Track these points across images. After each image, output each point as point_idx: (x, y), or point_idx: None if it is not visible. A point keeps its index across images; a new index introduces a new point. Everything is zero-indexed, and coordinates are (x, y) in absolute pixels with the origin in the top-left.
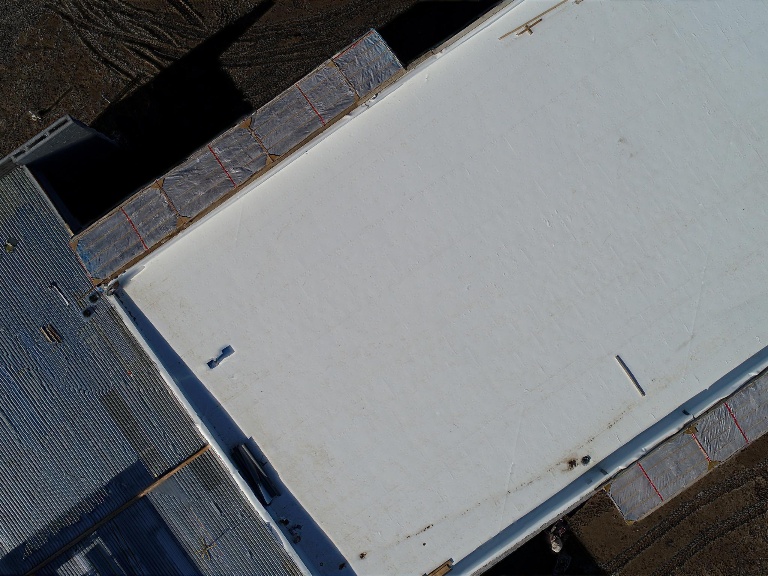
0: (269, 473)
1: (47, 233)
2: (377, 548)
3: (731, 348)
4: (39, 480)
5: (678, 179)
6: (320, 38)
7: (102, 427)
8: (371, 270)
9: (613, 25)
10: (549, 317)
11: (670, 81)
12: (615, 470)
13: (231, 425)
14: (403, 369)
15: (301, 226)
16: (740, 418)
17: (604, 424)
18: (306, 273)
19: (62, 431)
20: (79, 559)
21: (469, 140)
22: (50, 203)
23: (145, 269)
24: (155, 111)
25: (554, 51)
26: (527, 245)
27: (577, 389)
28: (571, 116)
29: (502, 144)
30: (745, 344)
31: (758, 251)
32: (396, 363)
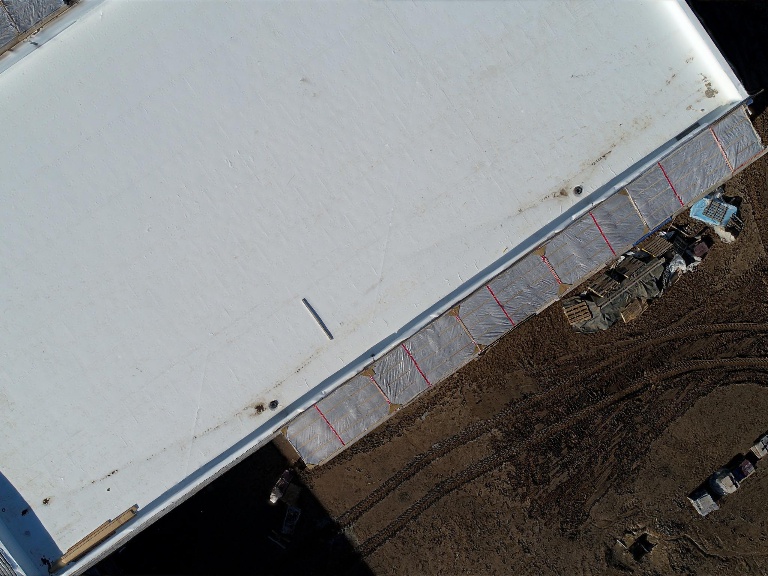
0: None
1: None
2: (61, 494)
3: (420, 291)
4: None
5: (363, 119)
6: None
7: None
8: (48, 211)
9: None
10: (233, 259)
11: (353, 19)
12: (293, 413)
13: None
14: (83, 312)
15: None
16: (420, 360)
17: (292, 368)
18: None
19: None
20: None
21: (147, 79)
22: None
23: None
24: None
25: None
26: (209, 186)
27: (263, 333)
28: (251, 54)
29: (181, 83)
30: (434, 287)
31: (447, 193)
32: (76, 306)
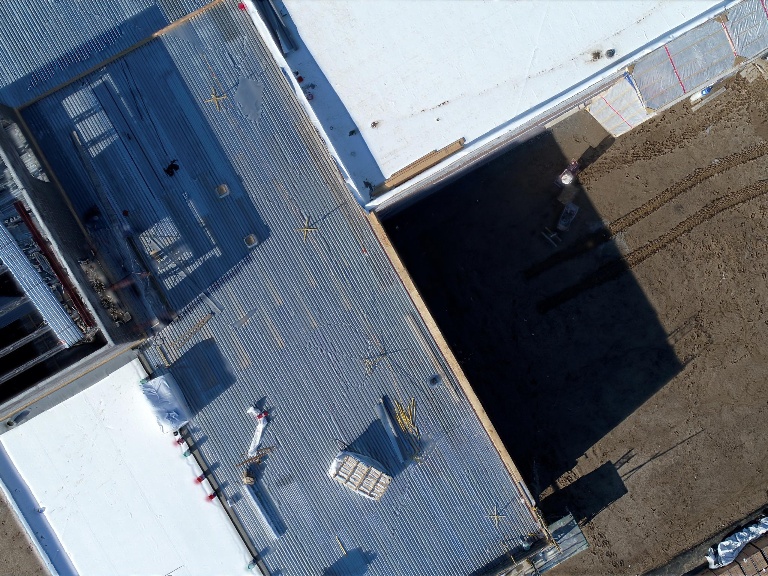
0: (288, 25)
1: None
2: (389, 118)
3: None
4: (52, 12)
5: None
6: None
7: None
8: None
9: None
10: None
11: None
12: (640, 53)
13: None
14: None
15: None
16: None
17: (632, 18)
18: None
19: None
20: (85, 93)
21: None
22: None
23: None
24: None
25: None
26: None
27: None
28: None
29: None
30: None
31: None
32: None
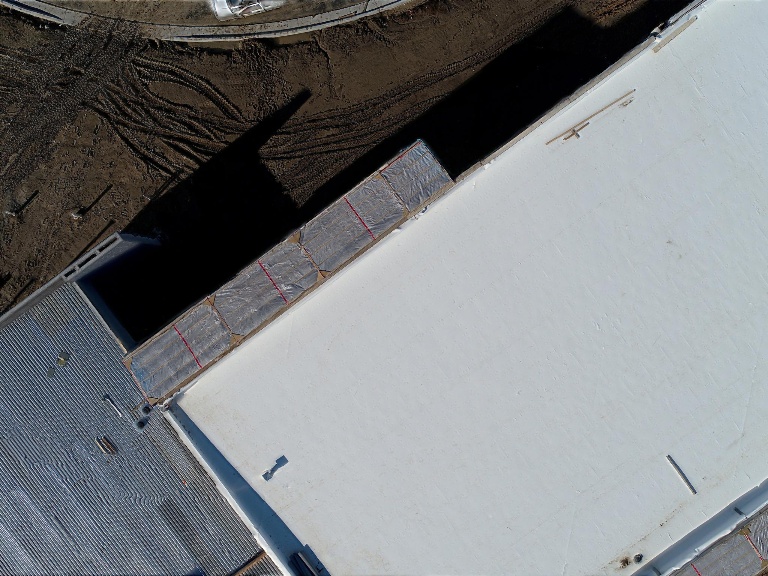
0: None
1: (98, 346)
2: None
3: None
4: None
5: (728, 279)
6: (358, 129)
7: (159, 536)
8: (422, 378)
9: (661, 126)
10: (600, 419)
11: (719, 181)
12: (668, 571)
13: (287, 533)
14: (455, 474)
15: (351, 336)
16: None
17: (656, 523)
18: (357, 382)
19: (119, 541)
20: None
21: (517, 246)
22: (101, 319)
23: (198, 383)
24: (195, 206)
25: (602, 154)
26: (577, 349)
27: (628, 489)
28: (619, 219)
29: (551, 249)
30: None
31: None
32: (448, 468)
